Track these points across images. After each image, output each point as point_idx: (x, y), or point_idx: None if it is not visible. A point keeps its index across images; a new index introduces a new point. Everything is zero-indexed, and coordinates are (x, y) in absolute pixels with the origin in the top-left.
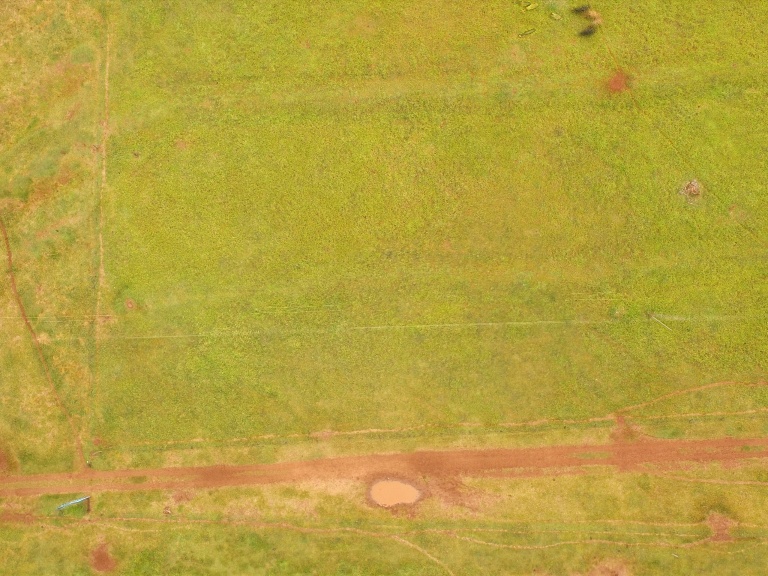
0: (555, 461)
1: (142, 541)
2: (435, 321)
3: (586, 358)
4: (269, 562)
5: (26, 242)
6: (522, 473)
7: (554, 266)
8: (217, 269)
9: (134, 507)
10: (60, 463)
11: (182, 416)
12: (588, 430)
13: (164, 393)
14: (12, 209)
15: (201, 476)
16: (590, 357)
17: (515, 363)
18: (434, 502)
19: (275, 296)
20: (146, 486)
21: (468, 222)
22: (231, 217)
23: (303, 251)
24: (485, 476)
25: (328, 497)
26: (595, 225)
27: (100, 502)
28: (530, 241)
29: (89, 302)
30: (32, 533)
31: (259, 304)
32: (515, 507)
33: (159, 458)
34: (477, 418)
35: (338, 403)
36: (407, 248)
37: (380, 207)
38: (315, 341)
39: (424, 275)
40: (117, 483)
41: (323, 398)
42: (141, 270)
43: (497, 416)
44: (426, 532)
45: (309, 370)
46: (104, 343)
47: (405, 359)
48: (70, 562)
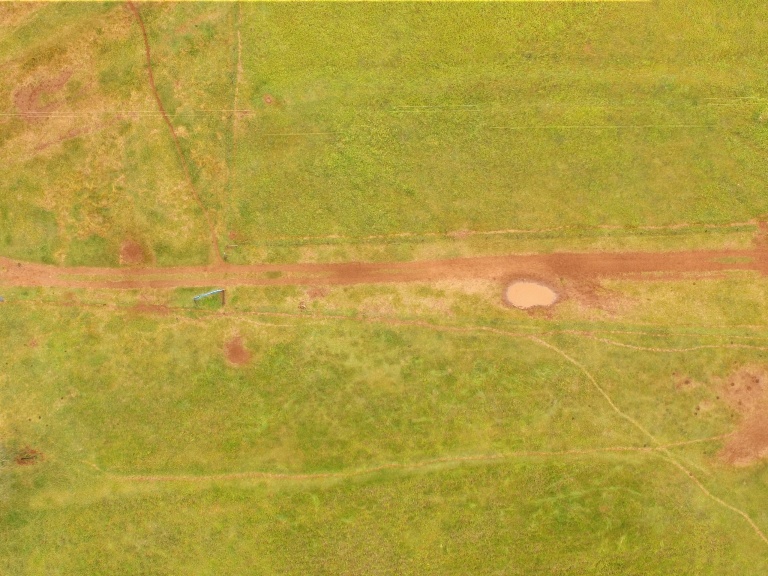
0: (695, 265)
1: (276, 335)
2: (575, 122)
3: (728, 163)
4: (404, 359)
5: (165, 37)
6: (662, 276)
7: (697, 70)
8: (355, 68)
9: (269, 302)
10: (195, 256)
11: (318, 212)
12: (730, 235)
13: (300, 189)
14: (151, 5)
15: (336, 273)
16: (732, 162)
17: (656, 166)
18: (571, 304)
19: (414, 94)
20: (281, 281)
21: (609, 26)
22: (370, 16)
23: (442, 51)
24: (624, 279)
25: (464, 296)
26: (738, 31)
27: (235, 296)
28: (672, 46)
29: (227, 98)
30: (167, 324)
31: (398, 102)
32: (654, 311)
33: (295, 253)
34: (616, 220)
35: (475, 203)
36: (547, 51)
37: (520, 9)
38: (453, 140)
39: (564, 77)
40: (252, 278)
41: (460, 197)
42: (279, 67)
43: (637, 218)
44: (563, 333)
45: (447, 169)
46: (241, 138)
47: (544, 160)
48: (205, 353)
